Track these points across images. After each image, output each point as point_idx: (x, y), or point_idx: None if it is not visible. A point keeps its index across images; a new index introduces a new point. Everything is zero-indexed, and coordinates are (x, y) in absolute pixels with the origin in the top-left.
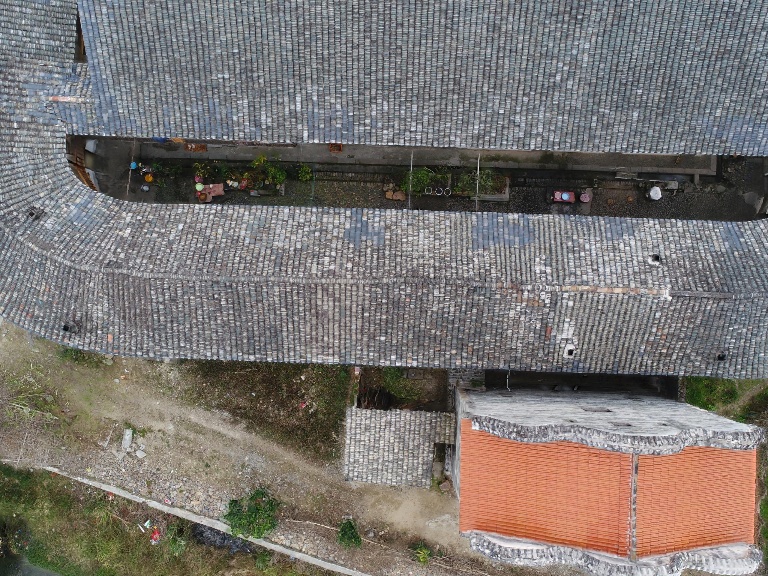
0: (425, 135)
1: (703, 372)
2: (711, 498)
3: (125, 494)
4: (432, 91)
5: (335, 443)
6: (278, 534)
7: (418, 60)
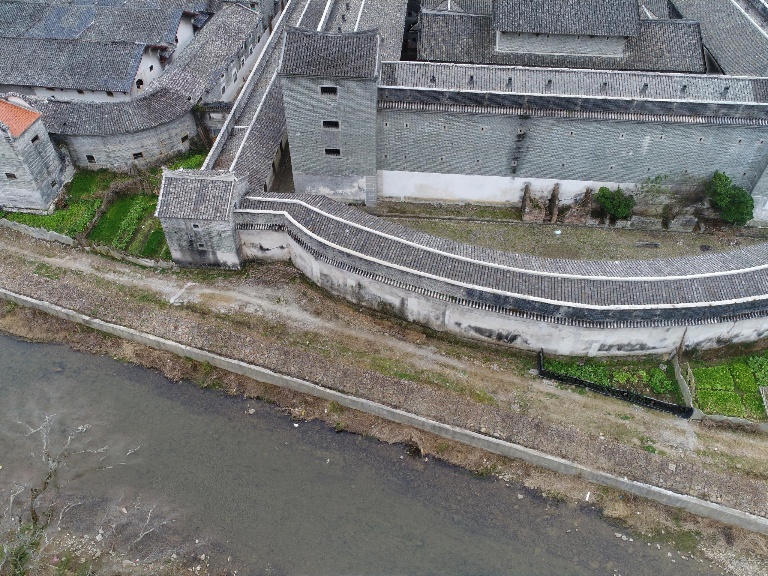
0: (0, 80)
1: (57, 130)
2: (4, 118)
3: None
4: (8, 68)
5: None
6: None
7: (6, 59)
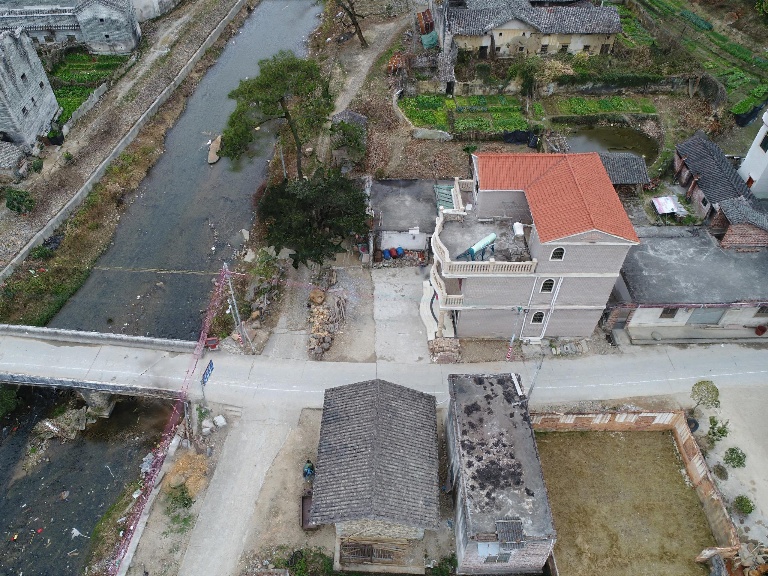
0: None
1: None
2: None
3: (2, 272)
4: None
5: (3, 188)
6: (51, 212)
7: None
